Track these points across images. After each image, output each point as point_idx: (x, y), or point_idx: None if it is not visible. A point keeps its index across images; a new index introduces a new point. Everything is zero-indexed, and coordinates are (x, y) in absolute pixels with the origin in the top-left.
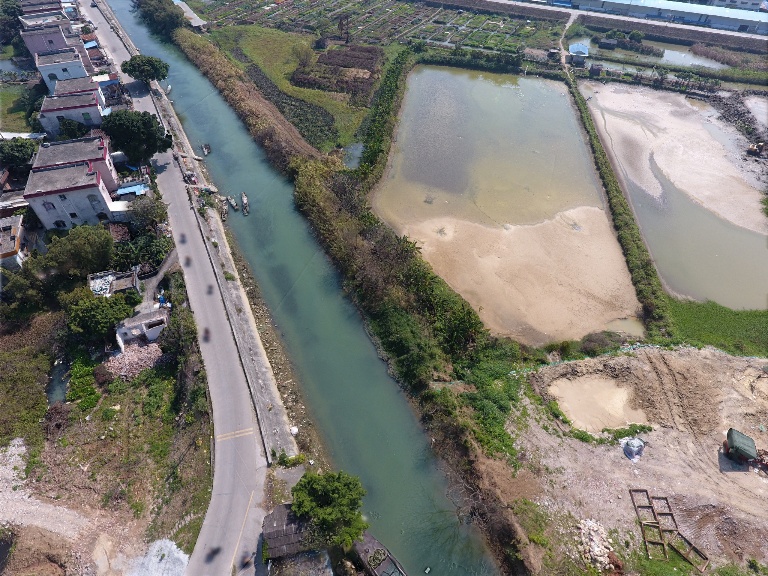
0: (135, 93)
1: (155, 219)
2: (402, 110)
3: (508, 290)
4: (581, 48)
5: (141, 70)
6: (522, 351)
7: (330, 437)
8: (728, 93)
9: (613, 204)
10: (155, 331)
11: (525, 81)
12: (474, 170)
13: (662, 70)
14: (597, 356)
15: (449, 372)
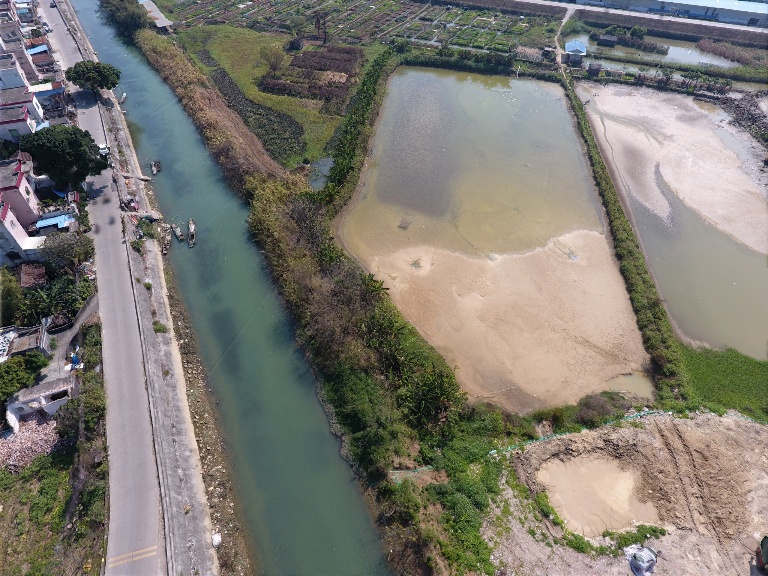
0: (81, 103)
1: (73, 259)
2: (380, 118)
3: (491, 338)
4: (578, 46)
5: (86, 78)
6: (505, 422)
7: (262, 546)
8: (740, 94)
9: (614, 228)
10: (56, 405)
11: (517, 83)
12: (457, 188)
13: (667, 69)
14: (596, 428)
15: (414, 455)
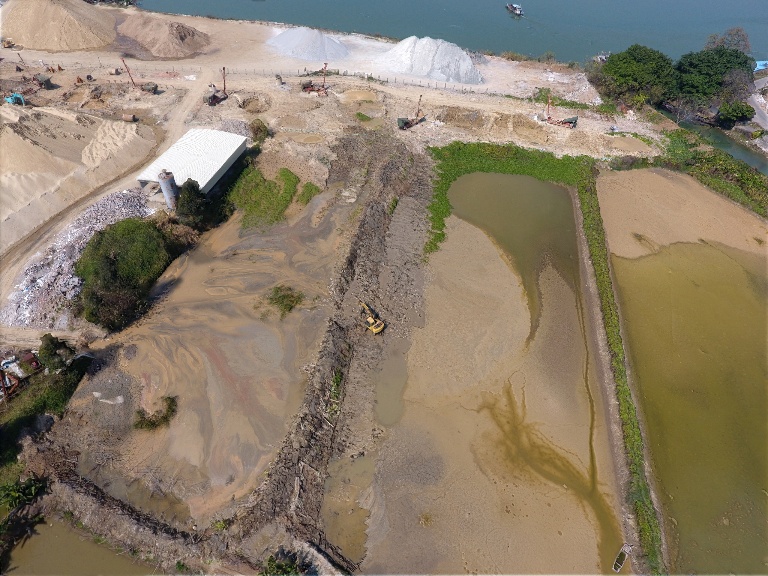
0: None
1: None
2: None
3: (685, 196)
4: None
5: None
6: (670, 161)
7: (745, 150)
8: (252, 548)
9: None
10: None
11: None
12: None
13: None
14: None
15: (708, 152)
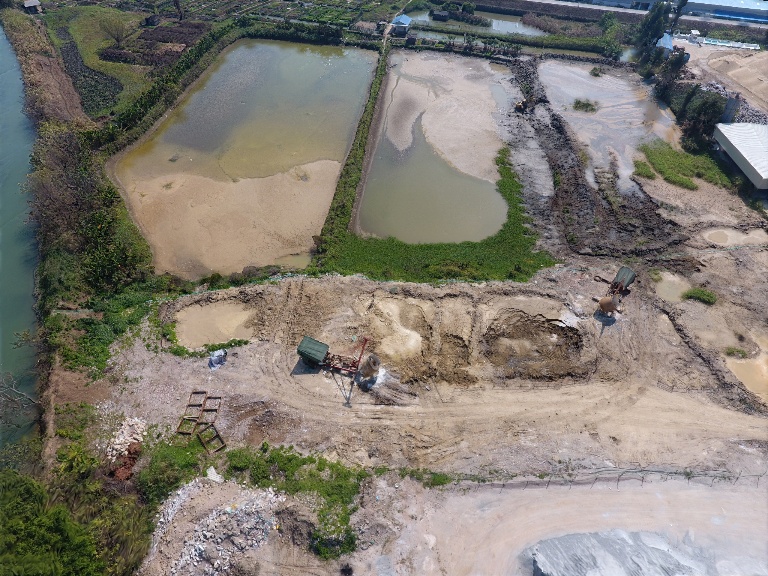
0: None
1: None
2: (199, 80)
3: (200, 234)
4: (402, 19)
5: None
6: (171, 283)
7: None
8: (529, 57)
9: (348, 156)
10: None
11: (347, 52)
12: (237, 131)
13: (470, 37)
14: (241, 285)
15: (80, 302)
